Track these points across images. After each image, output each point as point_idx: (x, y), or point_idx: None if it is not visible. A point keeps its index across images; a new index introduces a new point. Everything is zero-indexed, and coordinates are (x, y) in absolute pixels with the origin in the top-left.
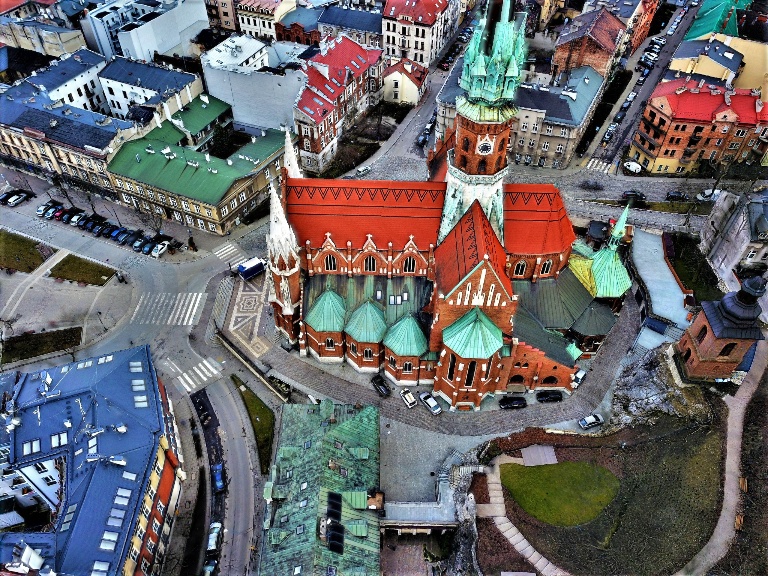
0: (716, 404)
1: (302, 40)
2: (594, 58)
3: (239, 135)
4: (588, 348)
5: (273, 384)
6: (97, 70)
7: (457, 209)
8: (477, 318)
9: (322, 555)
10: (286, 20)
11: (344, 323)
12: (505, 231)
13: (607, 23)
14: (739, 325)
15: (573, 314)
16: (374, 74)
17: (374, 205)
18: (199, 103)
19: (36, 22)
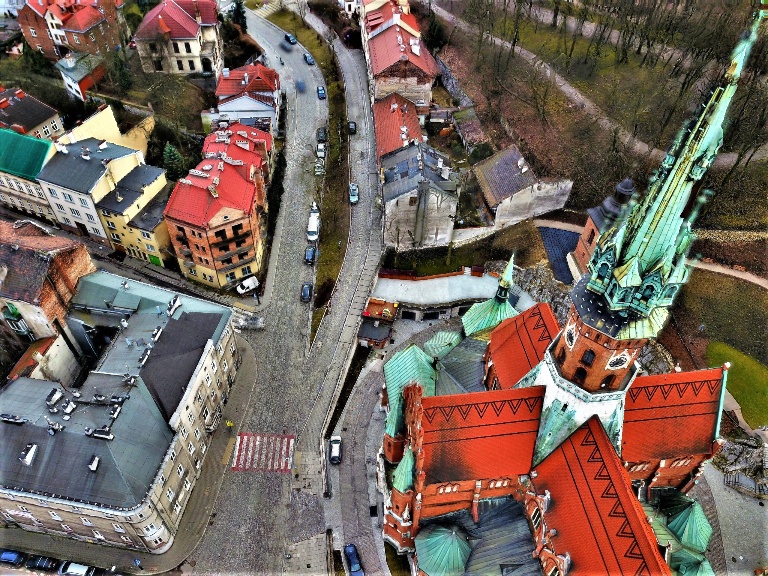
0: None
1: None
2: (76, 266)
3: None
4: None
5: None
6: None
7: None
8: None
9: None
10: None
11: None
12: None
13: None
14: None
15: None
16: None
17: None
18: None
19: None
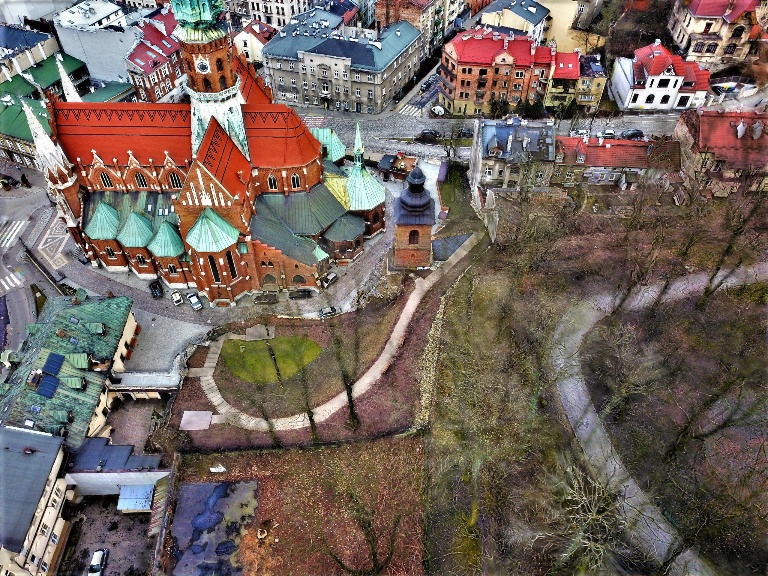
0: (407, 285)
1: None
2: (409, 13)
3: None
4: (343, 255)
5: (62, 289)
6: None
7: (199, 126)
8: (203, 215)
9: (28, 396)
10: None
11: (117, 232)
12: (250, 147)
13: None
14: (412, 212)
15: (322, 223)
16: None
17: (133, 125)
18: (54, 60)
19: None
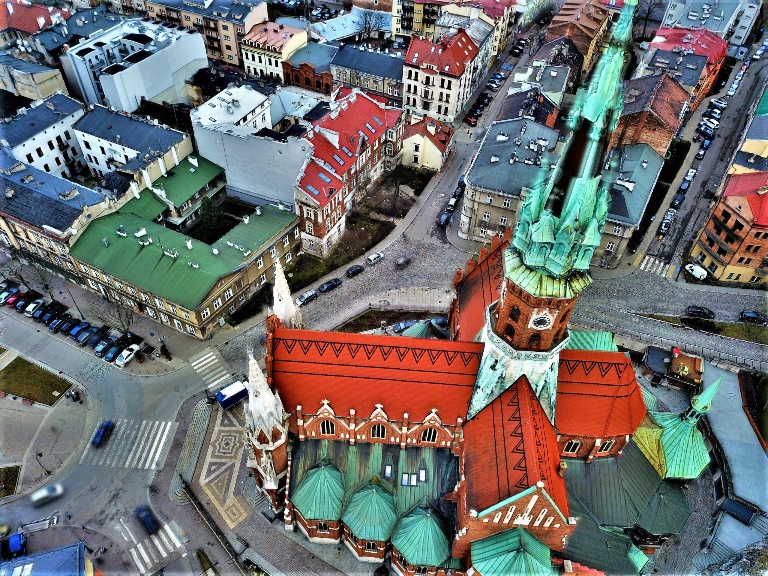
0: None
1: (312, 82)
2: (653, 136)
3: (233, 202)
4: (652, 542)
5: (248, 574)
6: (73, 119)
7: (497, 383)
8: (521, 548)
9: None
10: (295, 58)
11: (342, 508)
12: (557, 406)
13: (669, 93)
14: None
15: (638, 506)
16: (392, 137)
17: (387, 366)
18: (187, 166)
19: (10, 57)
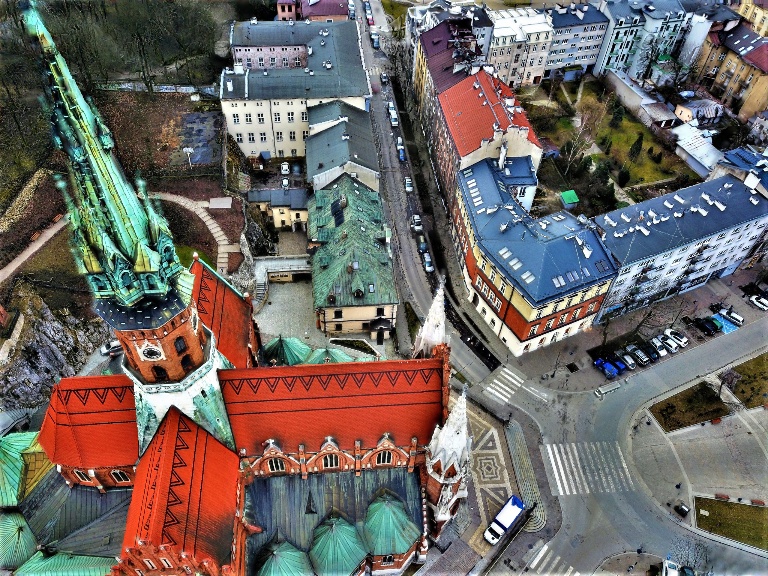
0: (6, 291)
1: None
2: None
3: None
4: None
5: None
6: None
7: None
8: None
9: None
10: None
11: None
12: None
13: None
14: None
15: None
16: None
17: None
18: None
19: None
